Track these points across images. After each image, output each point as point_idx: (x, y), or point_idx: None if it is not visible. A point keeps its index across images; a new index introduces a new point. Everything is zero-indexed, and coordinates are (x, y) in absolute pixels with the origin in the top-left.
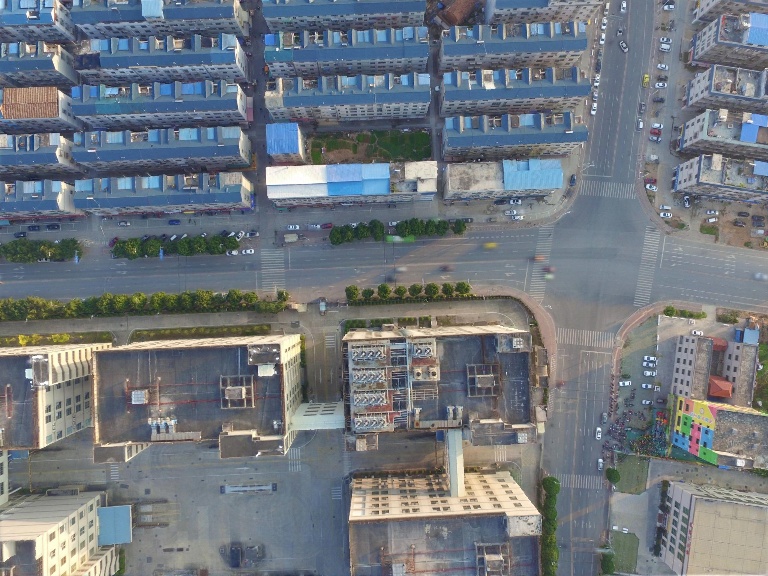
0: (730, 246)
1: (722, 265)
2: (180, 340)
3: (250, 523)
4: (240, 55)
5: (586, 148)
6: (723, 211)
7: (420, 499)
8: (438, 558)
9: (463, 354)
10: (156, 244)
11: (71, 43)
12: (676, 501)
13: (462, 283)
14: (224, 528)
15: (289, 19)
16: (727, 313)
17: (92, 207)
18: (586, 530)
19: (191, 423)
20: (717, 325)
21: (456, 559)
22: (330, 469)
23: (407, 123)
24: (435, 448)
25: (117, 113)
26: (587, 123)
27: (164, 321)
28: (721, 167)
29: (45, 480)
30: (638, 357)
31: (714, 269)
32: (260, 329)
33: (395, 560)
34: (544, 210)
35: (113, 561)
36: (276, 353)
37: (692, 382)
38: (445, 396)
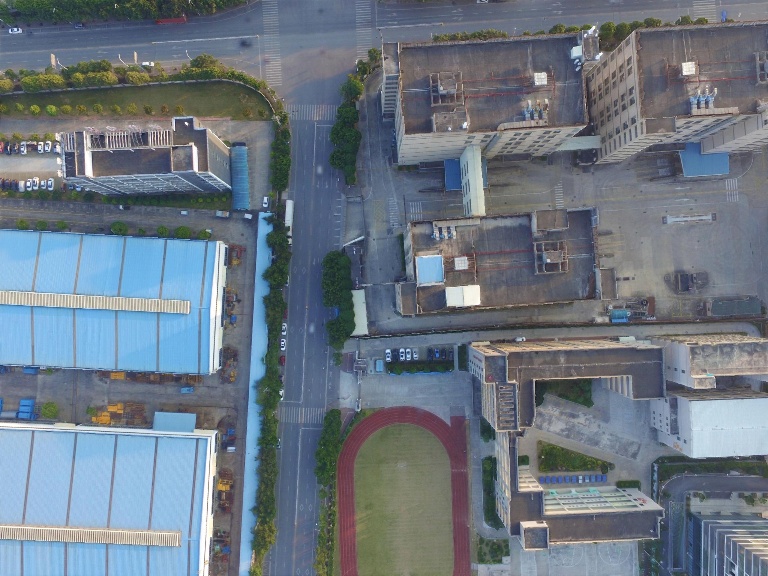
0: None
1: None
2: None
3: (692, 252)
4: None
5: None
6: None
7: None
8: None
9: None
10: None
11: None
12: None
13: None
14: (667, 257)
15: None
16: None
17: None
18: None
19: (726, 100)
20: None
21: None
22: (767, 198)
23: None
24: None
25: None
26: None
27: (601, 59)
28: None
29: None
30: None
31: None
32: None
33: None
34: None
35: None
36: None
37: None
38: None
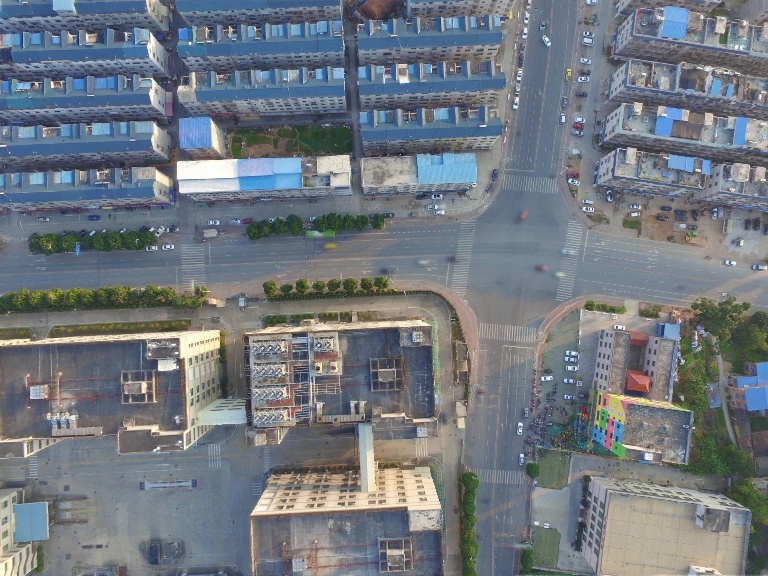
0: (653, 240)
1: (645, 259)
2: (97, 336)
3: (170, 519)
4: (156, 50)
5: (508, 142)
6: (646, 205)
7: (329, 494)
8: (341, 553)
9: (367, 348)
10: (71, 239)
11: None
12: (595, 496)
13: (380, 278)
14: (143, 525)
15: (204, 13)
16: (650, 307)
17: (4, 202)
18: (507, 525)
19: (93, 418)
20: (639, 319)
21: (359, 554)
22: (250, 465)
23: (328, 118)
24: (354, 443)
25: (29, 108)
26: (510, 117)
27: (83, 317)
28: (637, 161)
29: None
30: (560, 352)
31: (637, 263)
32: (179, 325)
33: (296, 555)
34: (466, 205)
35: (29, 558)
36: (175, 347)
37: (609, 376)
38: (349, 390)
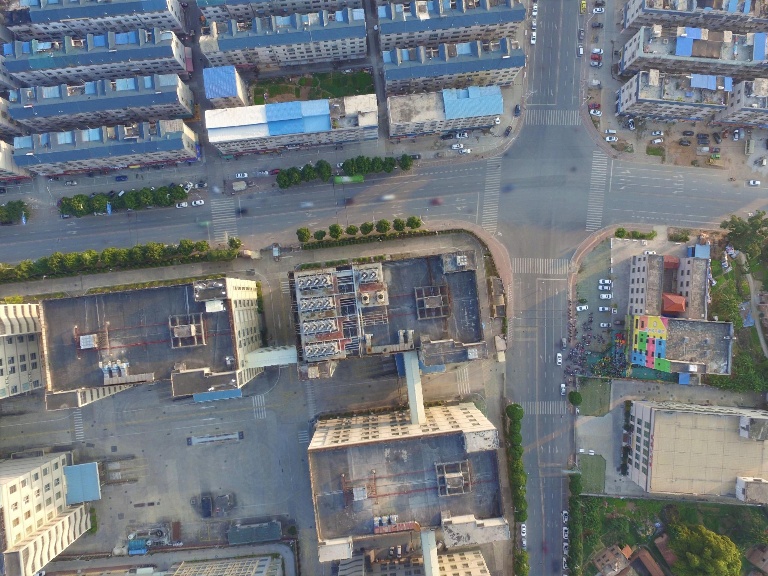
0: (677, 166)
1: (670, 185)
2: None
3: (219, 473)
4: (173, 4)
5: (529, 78)
6: (668, 132)
7: (381, 429)
8: (399, 481)
9: (411, 278)
10: (102, 199)
11: (3, 4)
12: (638, 418)
13: (412, 217)
14: (193, 479)
15: None
16: (678, 232)
17: (33, 164)
18: (553, 455)
19: (143, 365)
20: (669, 244)
21: (417, 481)
22: (295, 413)
23: (348, 64)
24: (397, 384)
25: (52, 67)
26: (528, 53)
27: (118, 278)
28: (659, 83)
29: (10, 445)
30: (593, 281)
31: (663, 189)
32: None
33: (356, 485)
34: (491, 142)
35: (83, 519)
36: (222, 288)
37: (645, 298)
38: (395, 321)
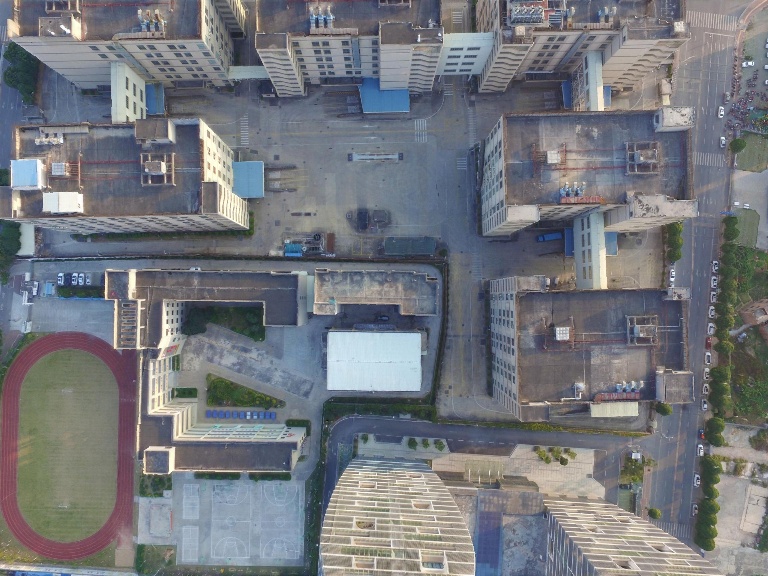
0: None
1: None
2: None
3: (376, 190)
4: None
5: None
6: None
7: None
8: (588, 157)
9: None
10: None
11: None
12: None
13: None
14: (351, 195)
15: None
16: None
17: None
18: (707, 206)
19: (348, 22)
20: None
21: (606, 158)
22: (456, 140)
23: None
24: None
25: None
26: None
27: None
28: None
29: None
30: (761, 40)
31: None
32: None
33: None
34: None
35: (246, 214)
36: None
37: None
38: (597, 2)
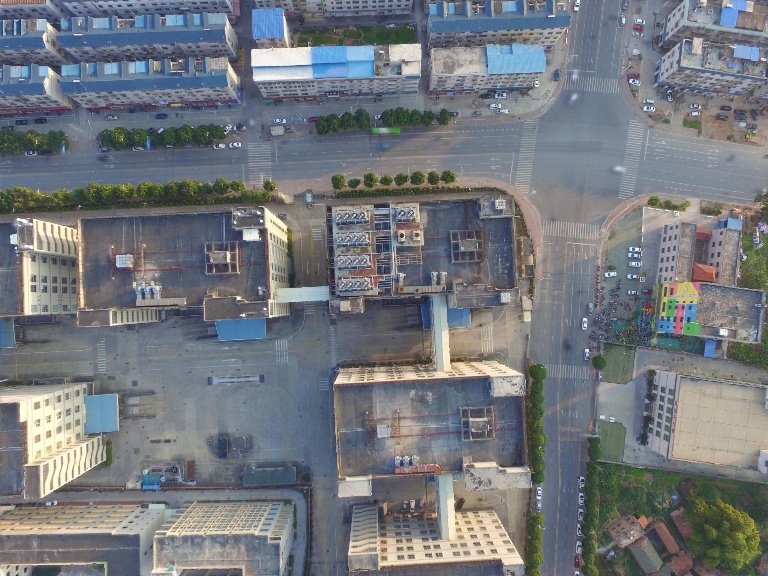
0: (713, 140)
1: (705, 158)
2: None
3: (237, 414)
4: None
5: (570, 44)
6: (706, 105)
7: (406, 373)
8: (423, 423)
9: (447, 221)
10: (143, 132)
11: None
12: (662, 386)
13: (447, 171)
14: (211, 419)
15: None
16: (711, 205)
17: (79, 91)
18: (573, 420)
19: (176, 290)
20: (701, 217)
21: (441, 423)
22: (317, 360)
23: (392, 19)
24: (422, 336)
25: None
26: None
27: None
28: (702, 52)
29: (32, 372)
30: (623, 249)
31: (697, 162)
32: None
33: (380, 423)
34: (529, 104)
35: (100, 449)
36: (260, 216)
37: (676, 266)
38: (429, 262)
